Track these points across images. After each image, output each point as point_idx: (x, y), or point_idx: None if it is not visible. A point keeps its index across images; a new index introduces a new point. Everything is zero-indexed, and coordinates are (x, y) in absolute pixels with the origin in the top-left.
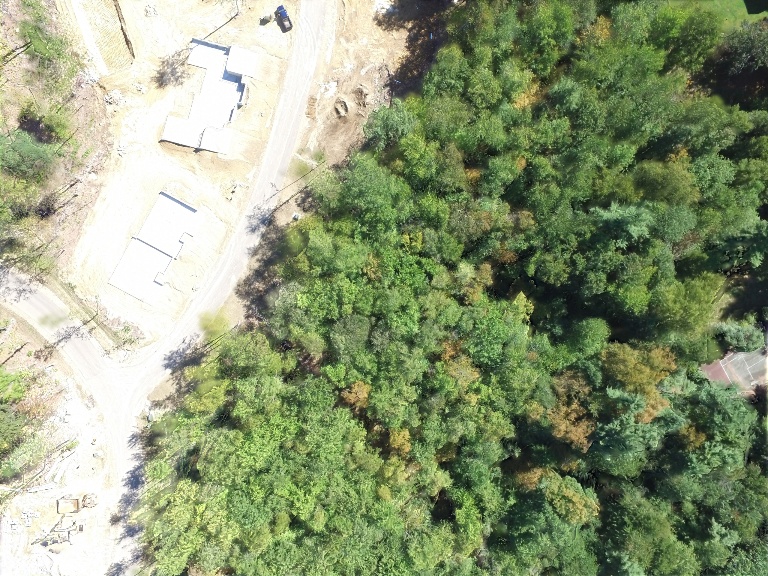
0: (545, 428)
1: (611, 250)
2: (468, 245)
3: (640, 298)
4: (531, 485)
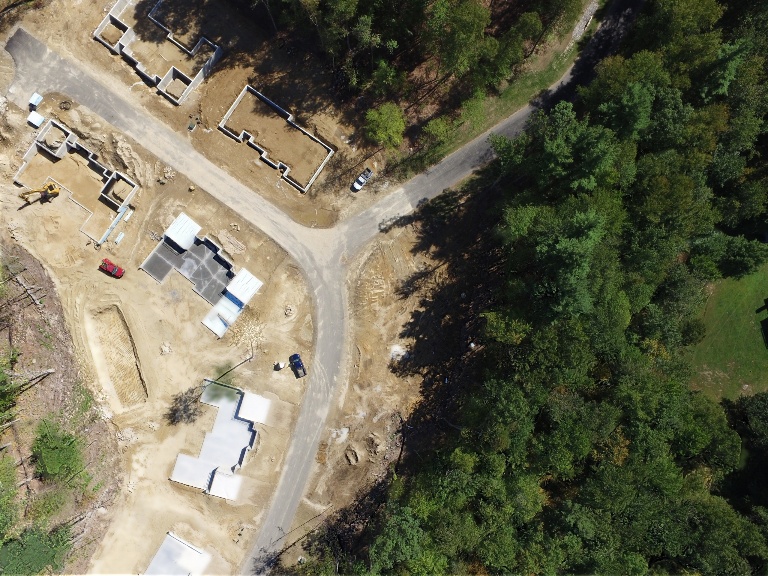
0: None
1: None
2: None
3: None
4: None
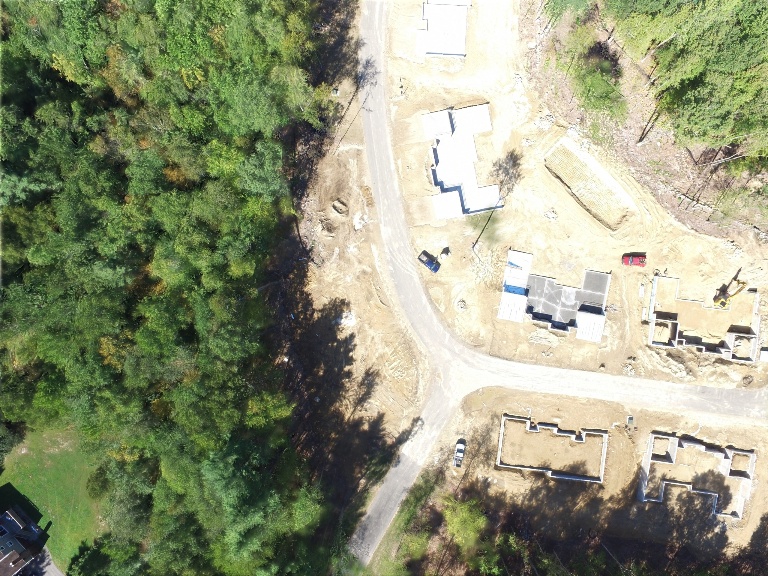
0: None
1: (1, 147)
2: None
3: None
4: None
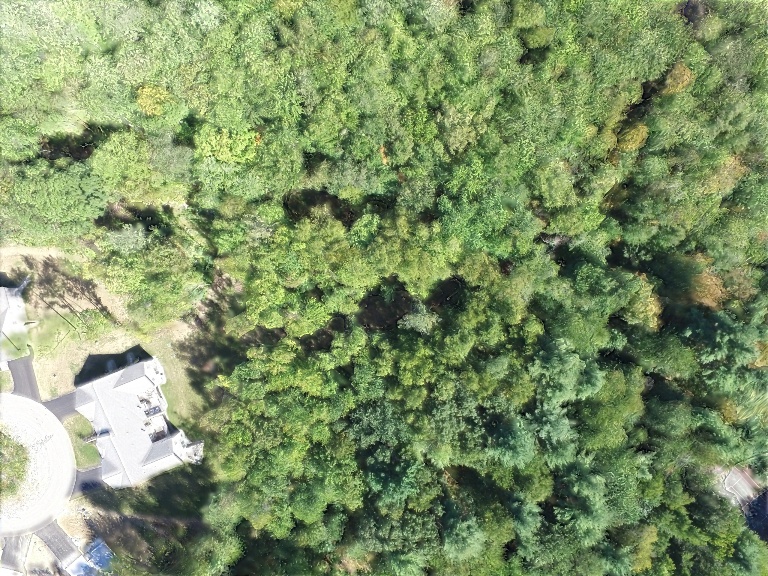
0: (691, 270)
1: None
2: None
3: None
4: None
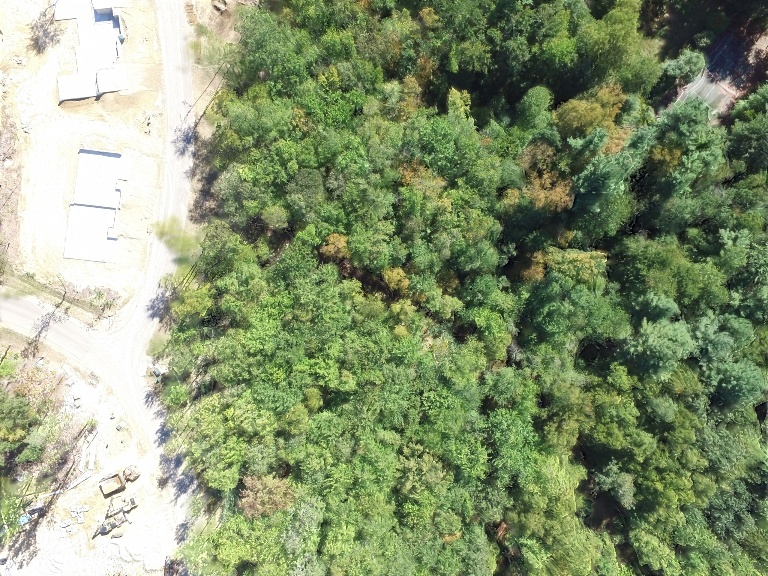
0: (528, 209)
1: (519, 10)
2: (385, 68)
3: (565, 44)
4: (539, 275)
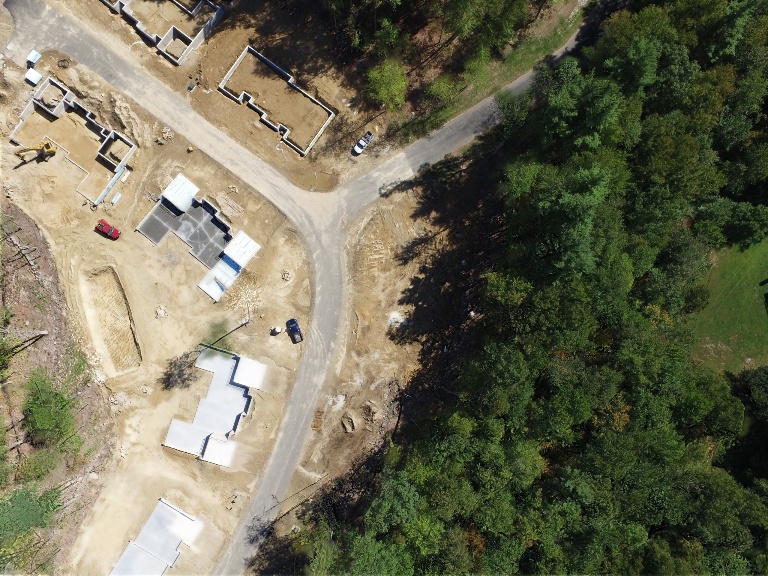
0: None
1: None
2: None
3: None
4: None
